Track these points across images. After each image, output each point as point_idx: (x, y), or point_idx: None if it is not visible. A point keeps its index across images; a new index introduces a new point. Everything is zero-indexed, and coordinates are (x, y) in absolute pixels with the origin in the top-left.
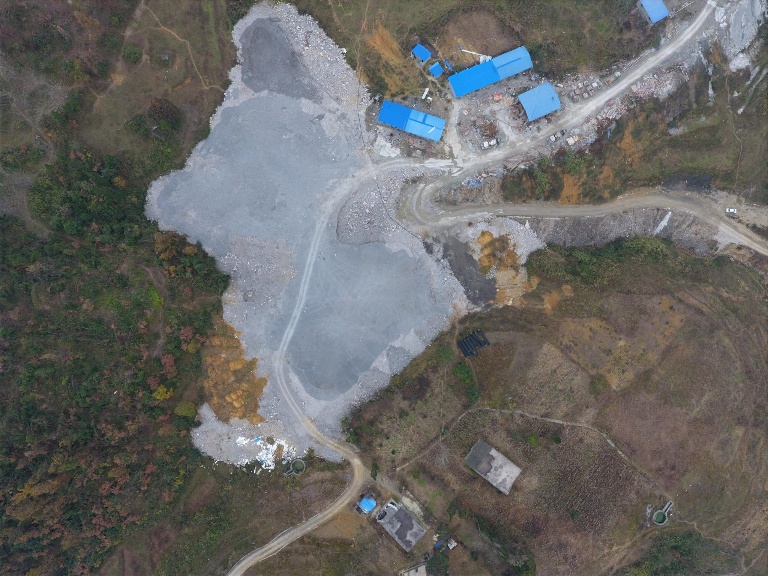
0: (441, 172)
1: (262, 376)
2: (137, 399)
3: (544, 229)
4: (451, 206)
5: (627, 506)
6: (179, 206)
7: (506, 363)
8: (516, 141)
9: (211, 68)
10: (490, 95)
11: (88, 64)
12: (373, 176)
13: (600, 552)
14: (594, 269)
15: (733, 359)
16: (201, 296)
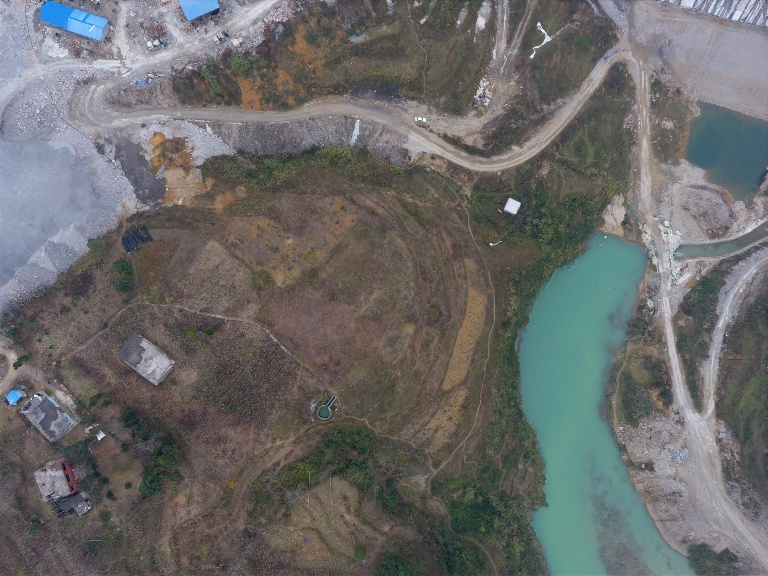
0: (110, 73)
1: None
2: None
3: (228, 134)
4: (125, 108)
5: (288, 400)
6: None
7: (166, 258)
8: (184, 43)
9: None
10: None
11: None
12: (40, 76)
13: (262, 446)
14: (276, 173)
15: (405, 259)
16: None
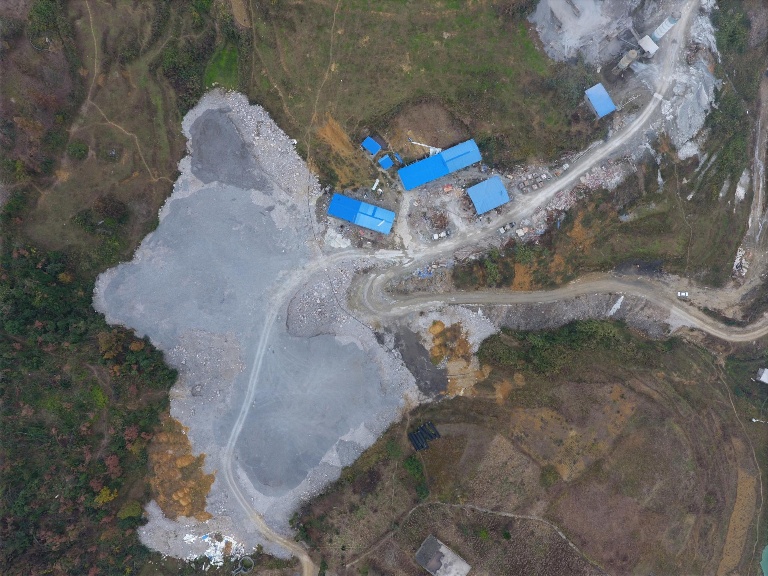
0: (392, 263)
1: (210, 473)
2: (80, 502)
3: (497, 315)
4: (403, 295)
5: None
6: (126, 299)
7: (456, 456)
8: (466, 232)
9: (160, 160)
10: (440, 186)
11: (30, 165)
12: (323, 267)
13: None
14: (547, 355)
15: (684, 447)
16: (148, 392)
